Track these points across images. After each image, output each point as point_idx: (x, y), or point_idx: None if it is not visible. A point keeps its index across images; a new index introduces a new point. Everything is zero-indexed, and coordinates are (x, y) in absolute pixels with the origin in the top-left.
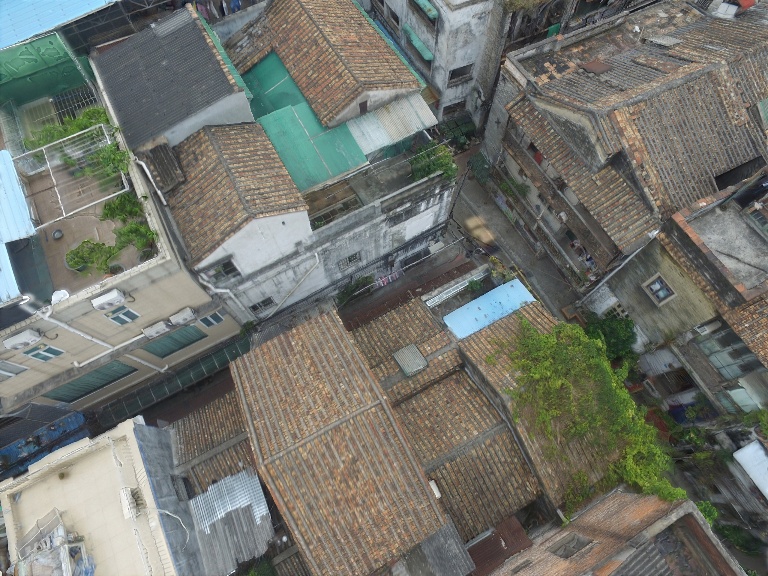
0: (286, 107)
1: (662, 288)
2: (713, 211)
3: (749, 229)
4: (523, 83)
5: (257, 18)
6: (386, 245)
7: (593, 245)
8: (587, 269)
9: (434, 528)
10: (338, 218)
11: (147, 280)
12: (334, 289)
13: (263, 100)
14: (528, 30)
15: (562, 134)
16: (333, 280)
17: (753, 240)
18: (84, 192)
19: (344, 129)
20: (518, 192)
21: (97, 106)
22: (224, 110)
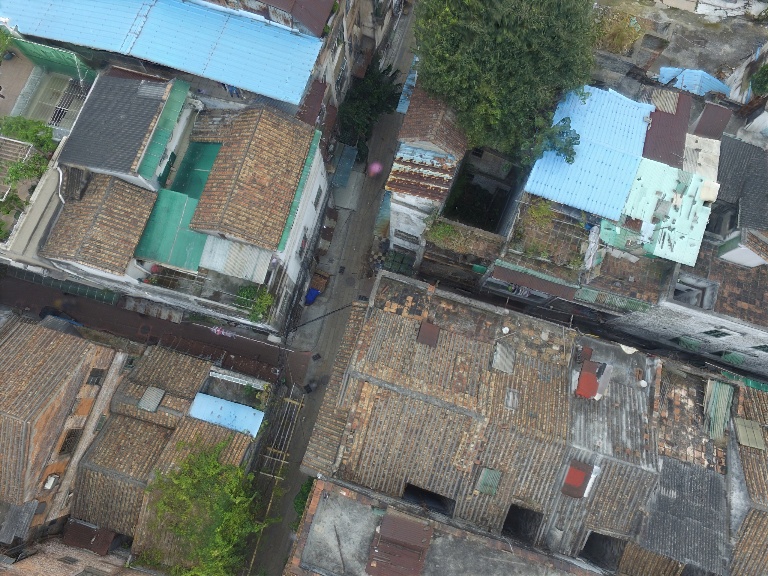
0: (184, 195)
1: None
2: None
3: (372, 535)
4: None
5: (236, 111)
6: None
7: None
8: None
9: (12, 502)
10: (162, 287)
11: None
12: None
13: (190, 172)
14: (452, 254)
15: None
16: (180, 306)
17: (365, 544)
18: None
19: (203, 238)
20: None
21: None
22: None
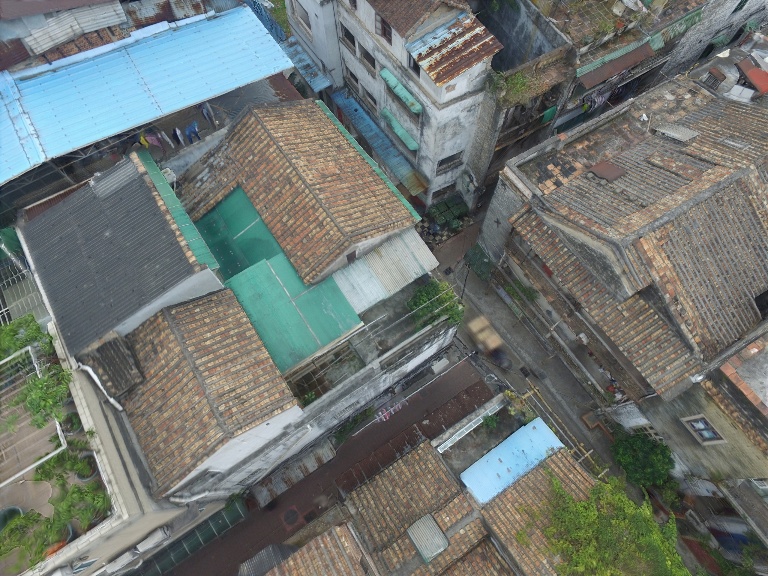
0: (260, 262)
1: (707, 429)
2: None
3: None
4: (527, 195)
5: (218, 146)
6: (386, 383)
7: (621, 374)
8: (610, 382)
9: None
10: (331, 389)
11: (101, 539)
12: (330, 432)
13: (232, 247)
14: (522, 118)
15: (578, 255)
16: (328, 427)
17: None
18: (8, 456)
19: (330, 283)
20: (526, 298)
21: (30, 282)
22: (185, 289)
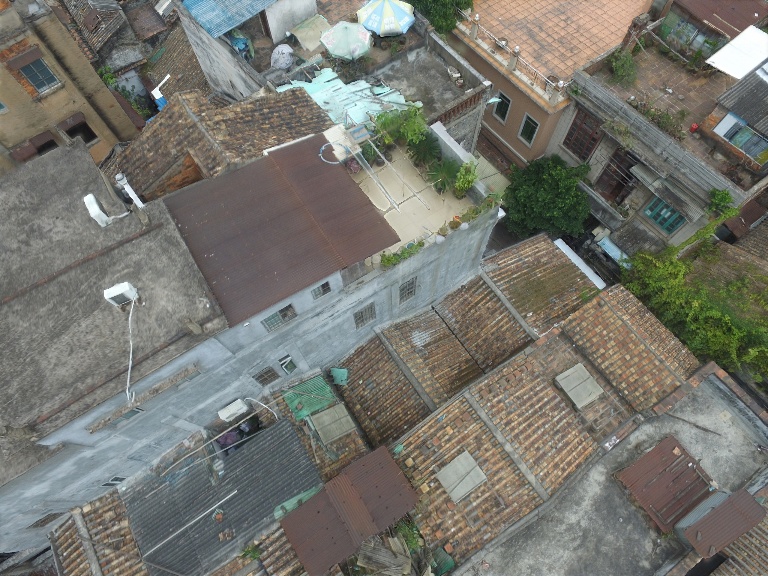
0: None
1: None
2: (734, 491)
3: None
4: None
5: None
6: None
7: None
8: None
9: None
10: None
11: None
12: None
13: None
14: None
15: None
16: None
17: None
18: None
19: None
20: None
21: None
22: None
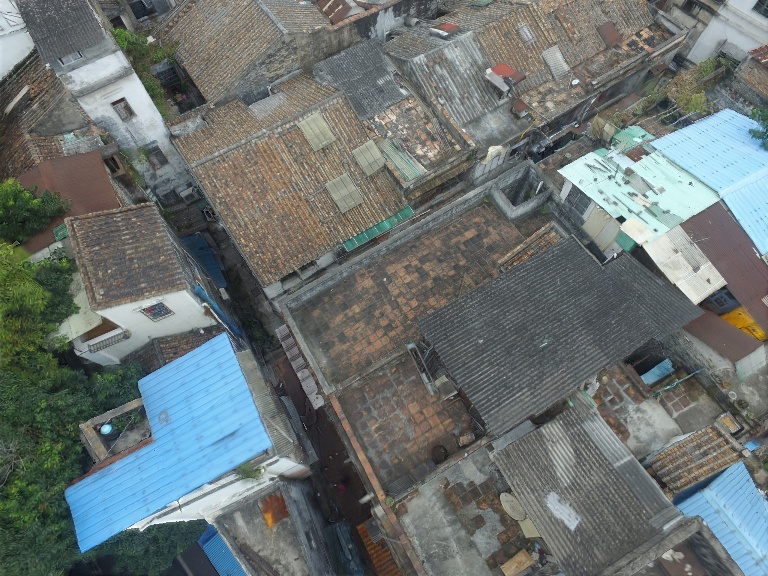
0: None
1: None
2: None
3: None
4: None
5: None
6: None
7: None
8: None
9: None
10: None
11: None
12: None
13: None
14: None
15: None
16: None
17: None
18: None
19: None
20: None
21: None
22: None
